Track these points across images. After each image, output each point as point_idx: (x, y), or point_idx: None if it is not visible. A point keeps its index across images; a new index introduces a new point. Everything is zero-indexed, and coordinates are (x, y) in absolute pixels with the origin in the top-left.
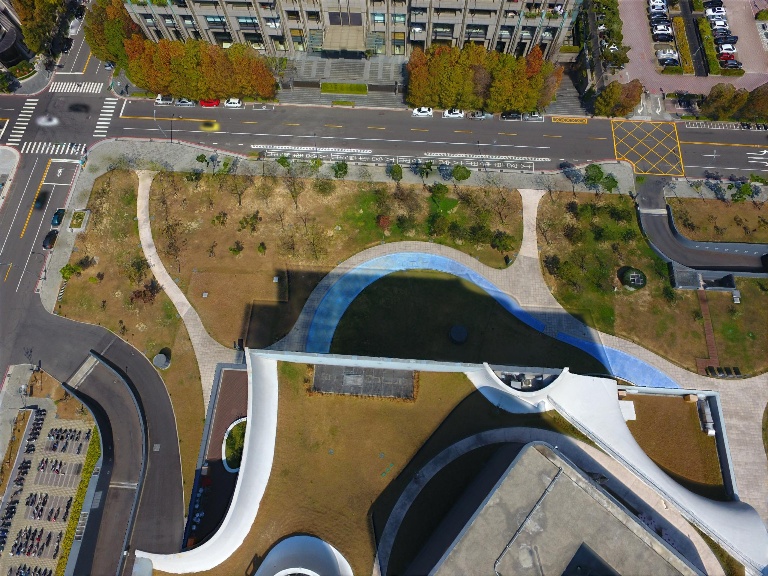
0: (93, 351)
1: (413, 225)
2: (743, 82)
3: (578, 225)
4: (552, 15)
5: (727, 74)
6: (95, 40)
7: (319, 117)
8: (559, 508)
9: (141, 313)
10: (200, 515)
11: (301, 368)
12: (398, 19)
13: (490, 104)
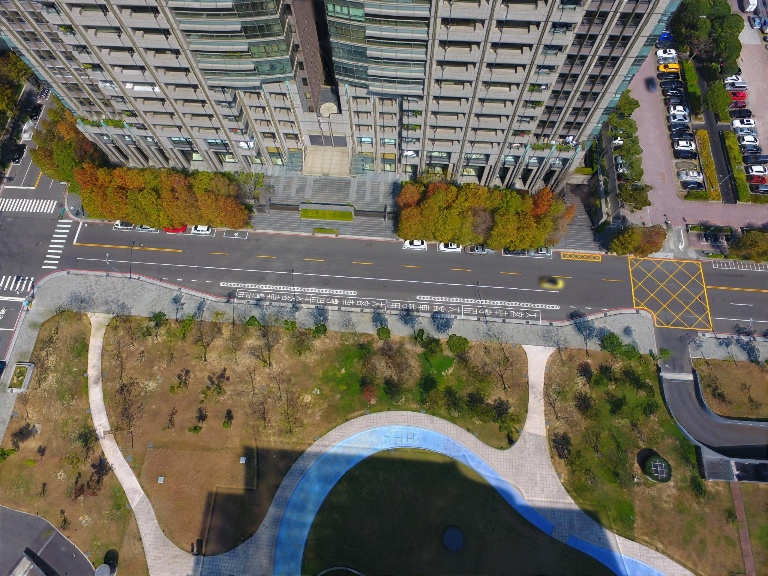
0: (28, 550)
1: (402, 397)
2: None
3: (591, 393)
4: (563, 147)
5: (758, 202)
6: (43, 164)
7: (298, 248)
8: None
9: (86, 501)
10: None
11: None
12: (388, 141)
13: (491, 244)
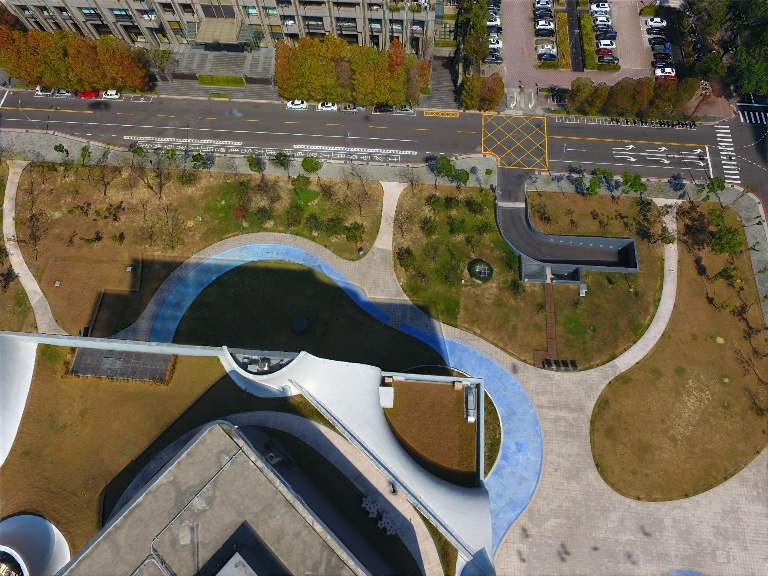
0: None
1: (267, 216)
2: (619, 77)
3: (435, 218)
4: (416, 8)
5: (603, 69)
6: None
7: (195, 109)
8: (230, 487)
9: None
10: None
11: (63, 351)
12: (272, 12)
13: (357, 97)
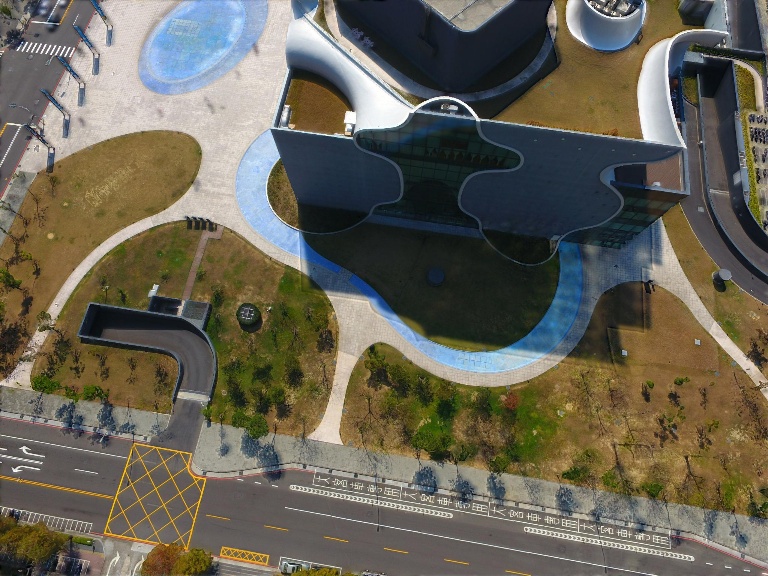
0: None
1: None
2: None
3: (284, 387)
4: None
5: None
6: None
7: None
8: (456, 3)
9: None
10: (673, 97)
11: None
12: None
13: None
